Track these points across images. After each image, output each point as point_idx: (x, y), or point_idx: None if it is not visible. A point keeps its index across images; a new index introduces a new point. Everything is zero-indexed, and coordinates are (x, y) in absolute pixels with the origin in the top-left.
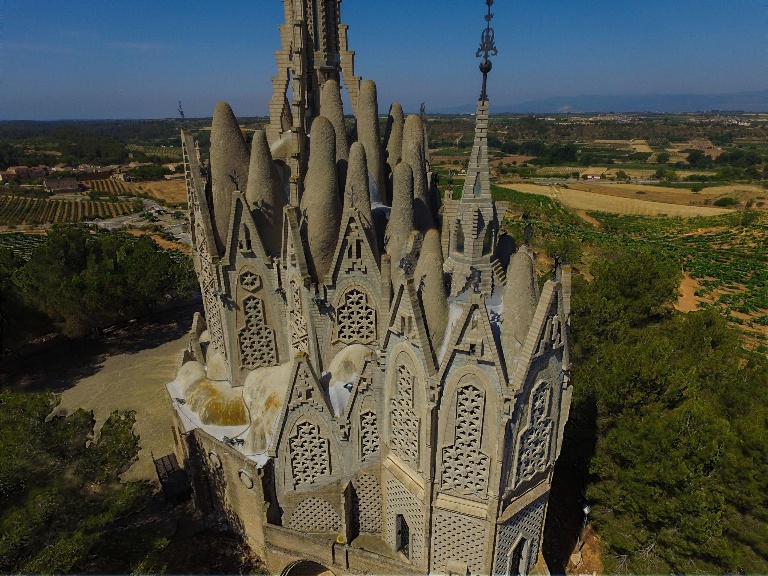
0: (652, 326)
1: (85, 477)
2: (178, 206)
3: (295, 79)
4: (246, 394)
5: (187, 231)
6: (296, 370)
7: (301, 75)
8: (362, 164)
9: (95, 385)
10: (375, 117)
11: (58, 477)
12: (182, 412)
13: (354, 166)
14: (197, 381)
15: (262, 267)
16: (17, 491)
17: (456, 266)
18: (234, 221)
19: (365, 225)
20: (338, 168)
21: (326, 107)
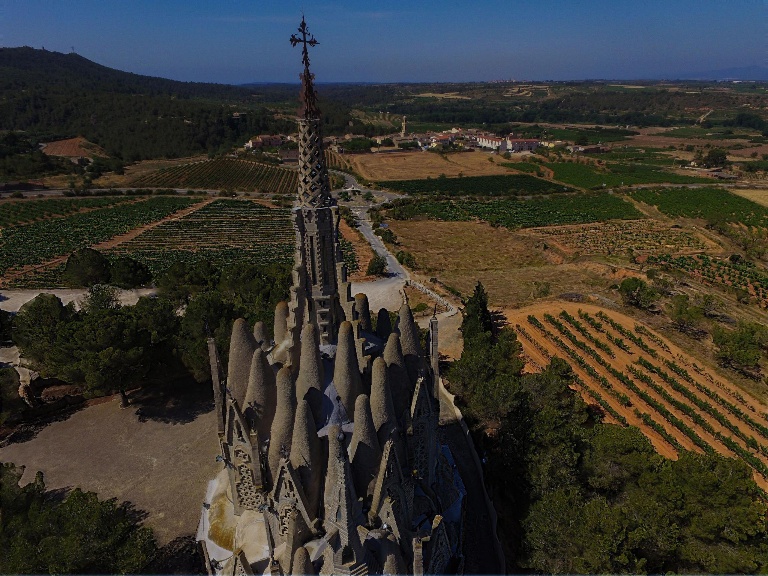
0: (724, 547)
1: (115, 570)
2: (372, 185)
3: (291, 311)
4: (236, 529)
5: (367, 219)
6: (235, 560)
7: (297, 307)
8: (304, 420)
9: (204, 425)
10: (348, 353)
11: (102, 564)
12: (203, 518)
13: (297, 420)
14: (219, 495)
15: (250, 449)
16: (72, 575)
17: (327, 559)
18: (229, 418)
19: (304, 464)
20: (310, 393)
21: (303, 346)
